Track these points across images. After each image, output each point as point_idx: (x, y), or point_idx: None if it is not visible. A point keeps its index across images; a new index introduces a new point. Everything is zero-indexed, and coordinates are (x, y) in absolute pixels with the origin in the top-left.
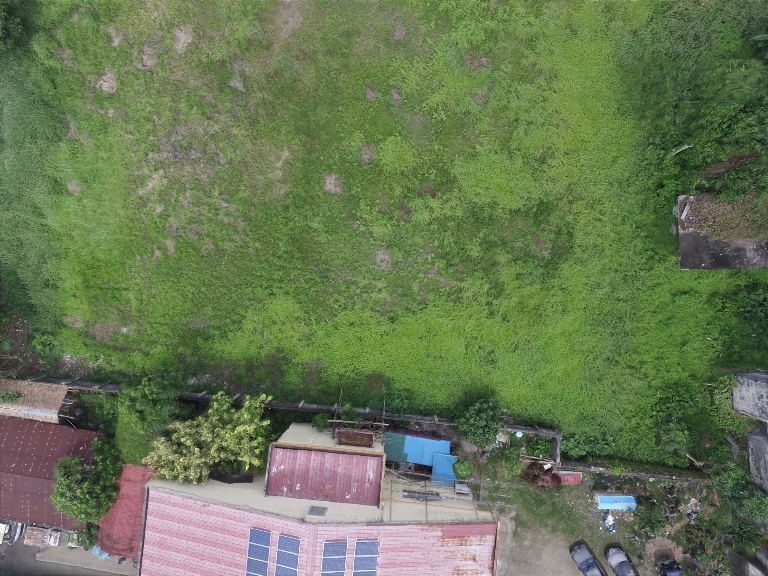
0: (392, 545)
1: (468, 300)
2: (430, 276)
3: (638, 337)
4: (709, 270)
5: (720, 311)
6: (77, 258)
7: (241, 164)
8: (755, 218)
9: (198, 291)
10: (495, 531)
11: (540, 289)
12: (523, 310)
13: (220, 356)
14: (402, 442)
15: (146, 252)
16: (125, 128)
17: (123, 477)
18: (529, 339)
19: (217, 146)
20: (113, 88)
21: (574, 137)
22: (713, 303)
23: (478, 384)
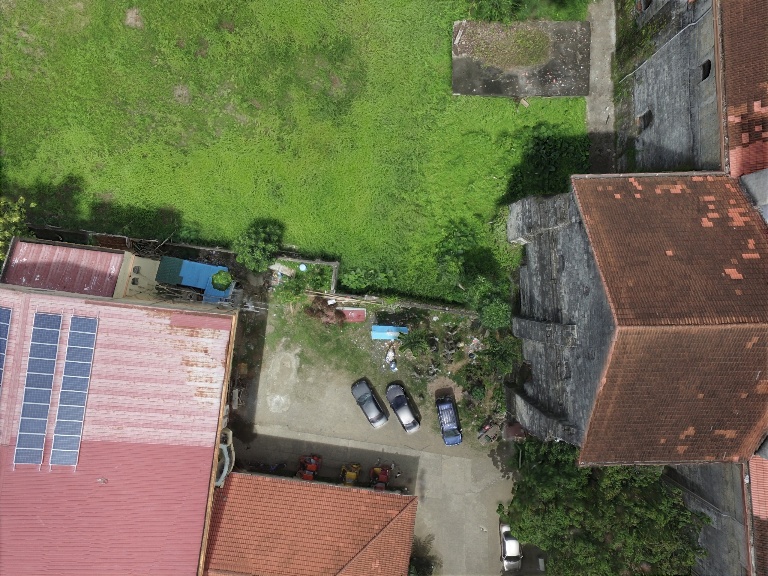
0: (113, 326)
1: (261, 135)
2: (226, 112)
3: (427, 177)
4: (494, 107)
5: (507, 151)
6: None
7: None
8: (527, 45)
9: None
10: (230, 326)
11: (331, 125)
12: (314, 146)
13: (13, 184)
14: (179, 266)
15: None
16: None
17: None
18: (318, 174)
19: None
20: None
21: None
22: (499, 141)
23: (266, 218)
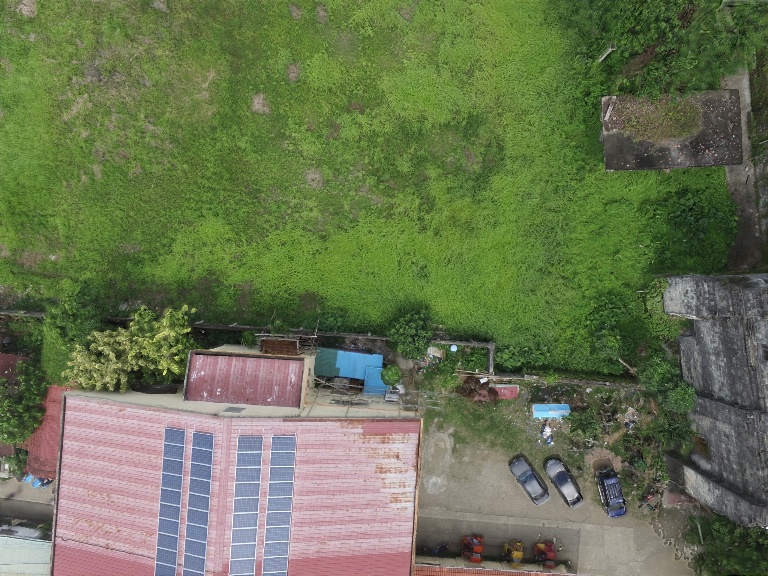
0: (311, 441)
1: (400, 216)
2: (362, 194)
3: (571, 248)
4: (638, 176)
5: (651, 218)
6: (1, 185)
7: (167, 86)
8: (678, 117)
9: (127, 216)
10: (418, 429)
11: (472, 202)
12: (455, 224)
13: (151, 281)
14: (334, 357)
15: (72, 178)
16: (47, 52)
17: (48, 398)
18: (462, 253)
19: (142, 68)
20: (34, 12)
21: (502, 49)
22: (644, 210)
23: (412, 300)
